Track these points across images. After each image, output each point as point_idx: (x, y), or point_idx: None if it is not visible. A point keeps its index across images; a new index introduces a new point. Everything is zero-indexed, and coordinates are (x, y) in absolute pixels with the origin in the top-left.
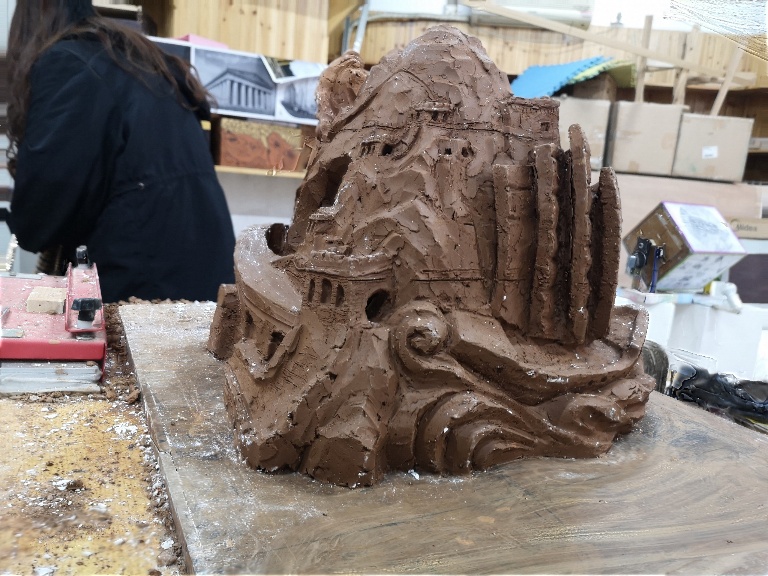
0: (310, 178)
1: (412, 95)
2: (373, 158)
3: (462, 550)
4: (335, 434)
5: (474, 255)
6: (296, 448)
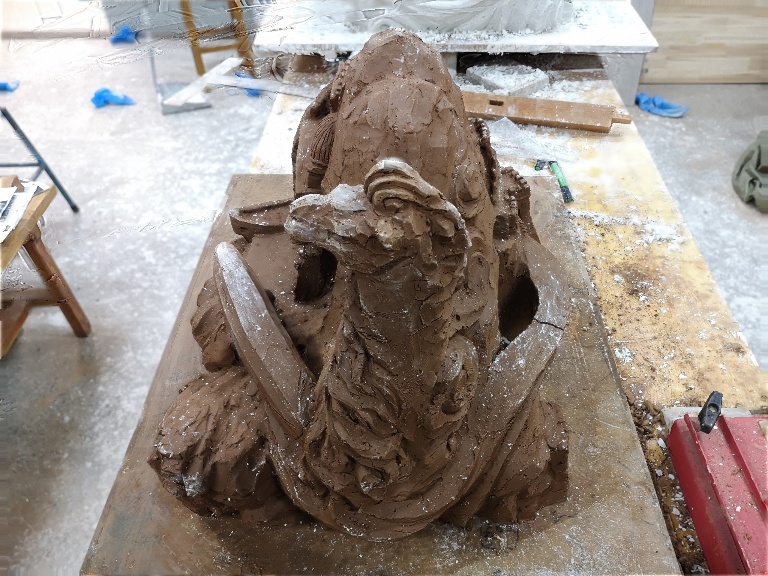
0: None
1: None
2: None
3: None
4: None
5: None
6: None
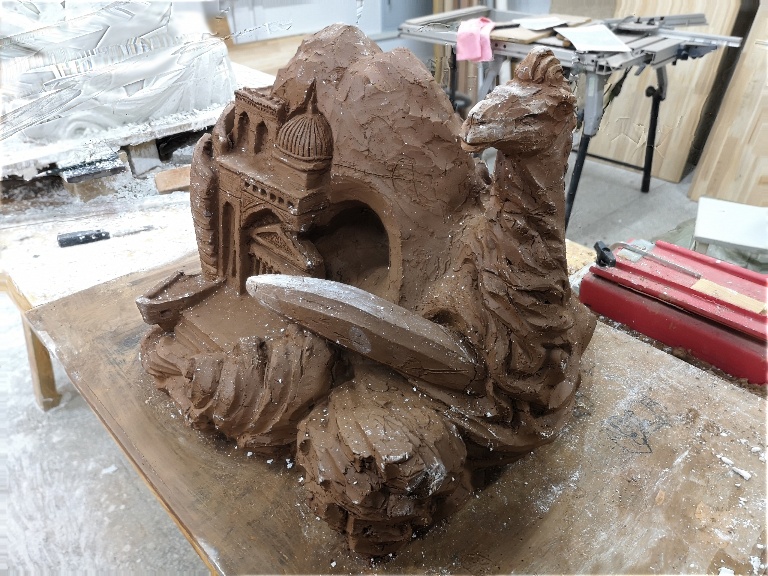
0: None
1: None
2: None
3: None
4: None
5: None
6: None
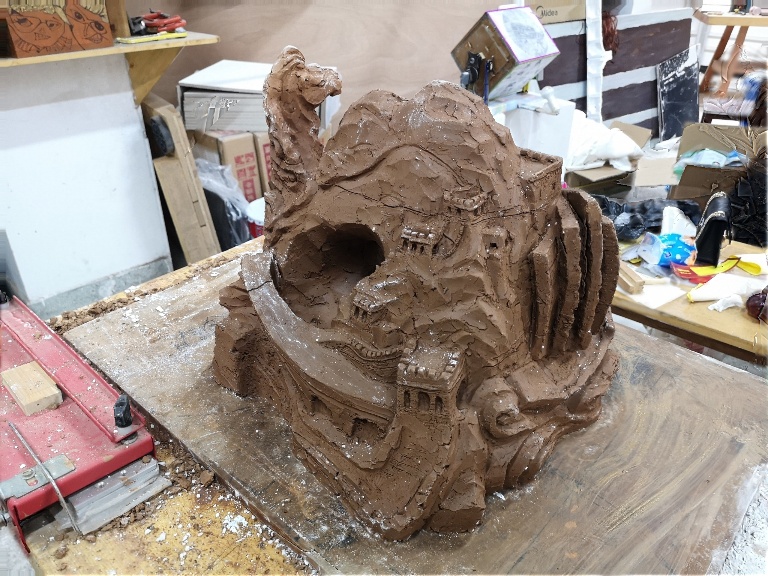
0: (309, 229)
1: (441, 181)
2: (425, 260)
3: (576, 565)
4: (459, 507)
5: (521, 325)
6: (424, 520)
